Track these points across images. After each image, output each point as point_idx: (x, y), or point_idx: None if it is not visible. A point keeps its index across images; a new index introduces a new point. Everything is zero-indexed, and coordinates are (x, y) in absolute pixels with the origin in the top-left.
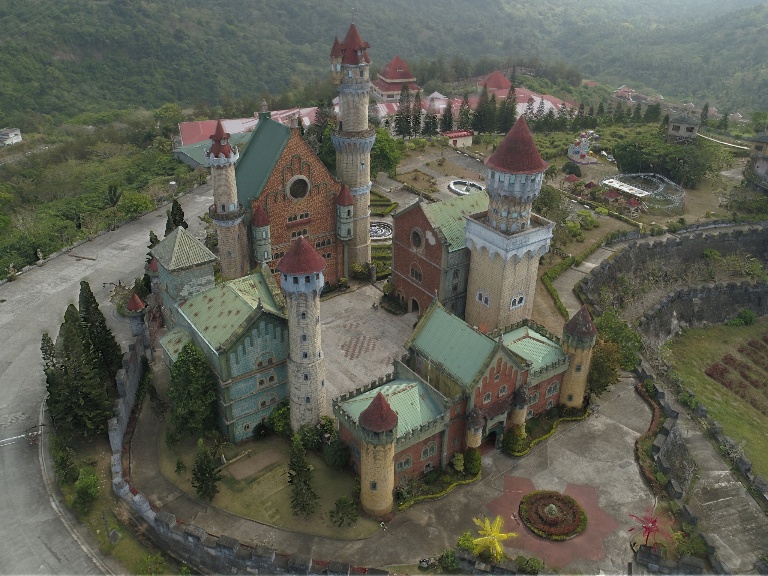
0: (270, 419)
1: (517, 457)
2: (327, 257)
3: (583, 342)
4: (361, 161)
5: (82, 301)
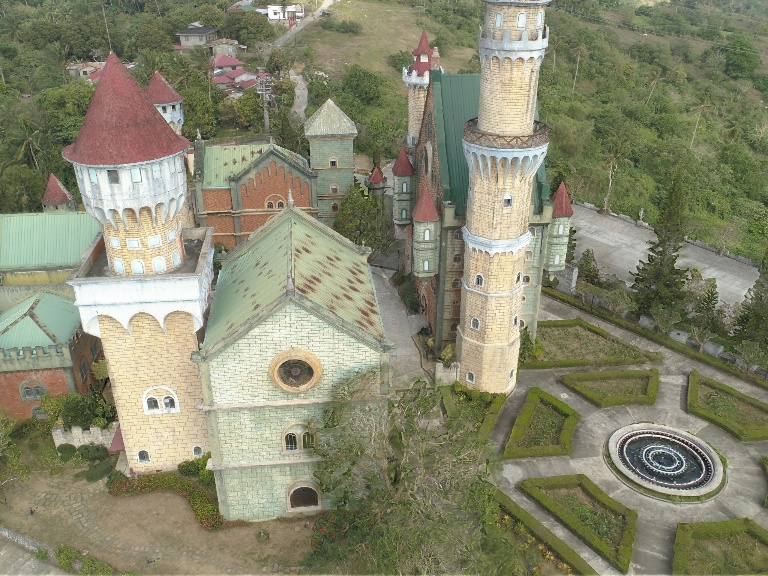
0: None
1: None
2: None
3: None
4: None
5: None
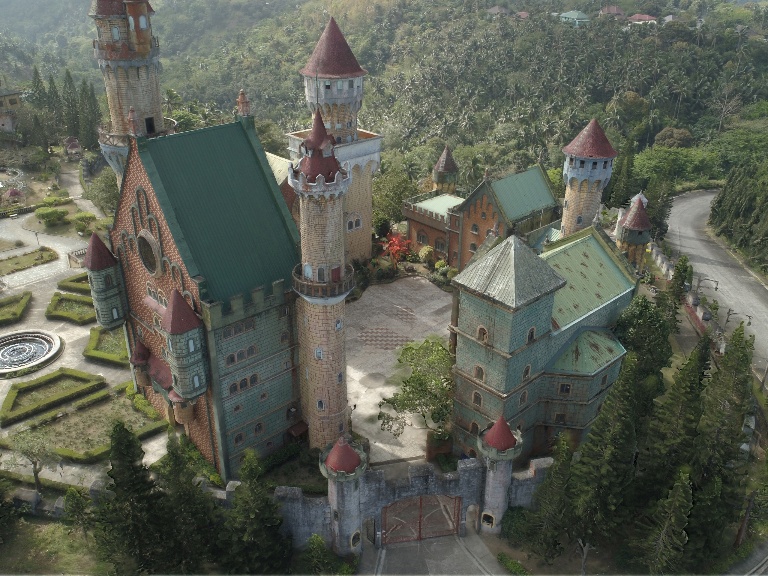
0: None
1: None
2: None
3: None
4: None
5: None
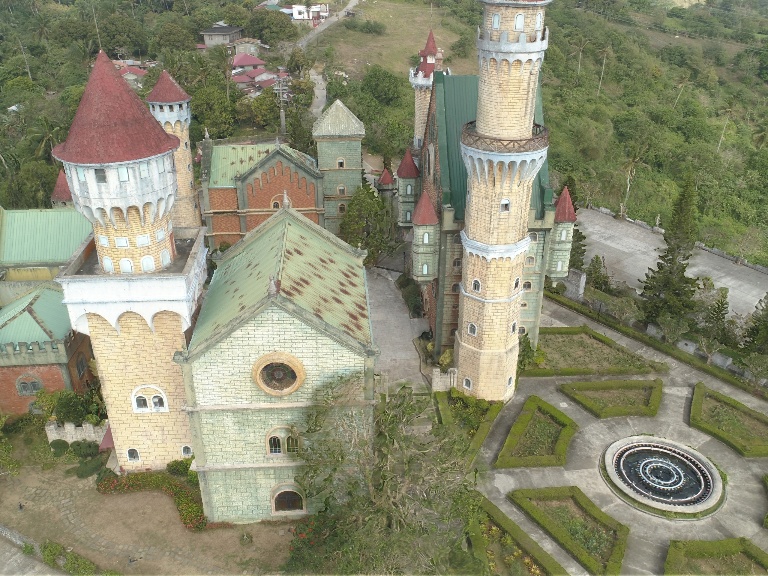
0: None
1: None
2: None
3: None
4: None
5: None
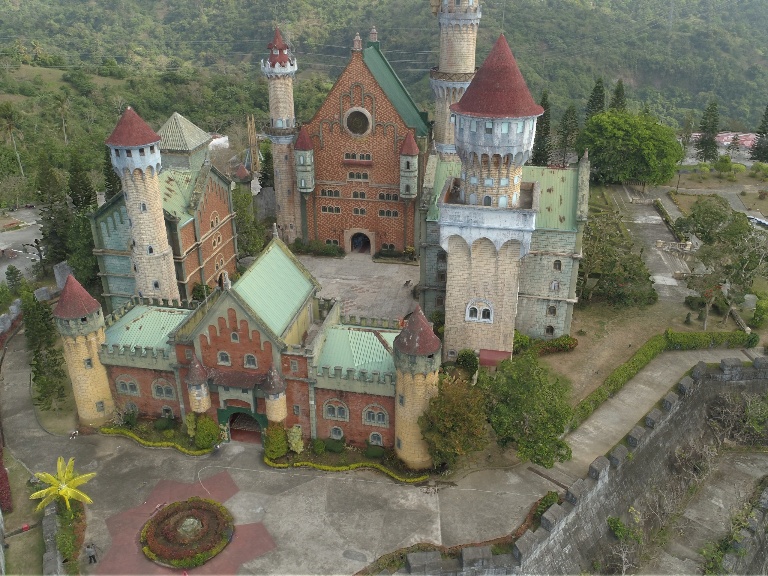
0: None
1: (267, 465)
2: (394, 215)
3: (400, 359)
4: None
5: None
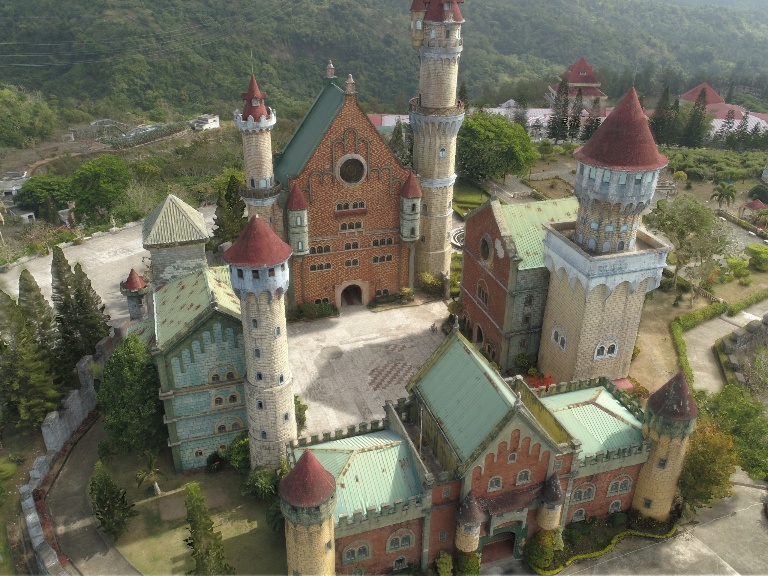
0: (230, 449)
1: (541, 575)
2: (387, 259)
3: (671, 426)
4: (441, 146)
5: (54, 269)
